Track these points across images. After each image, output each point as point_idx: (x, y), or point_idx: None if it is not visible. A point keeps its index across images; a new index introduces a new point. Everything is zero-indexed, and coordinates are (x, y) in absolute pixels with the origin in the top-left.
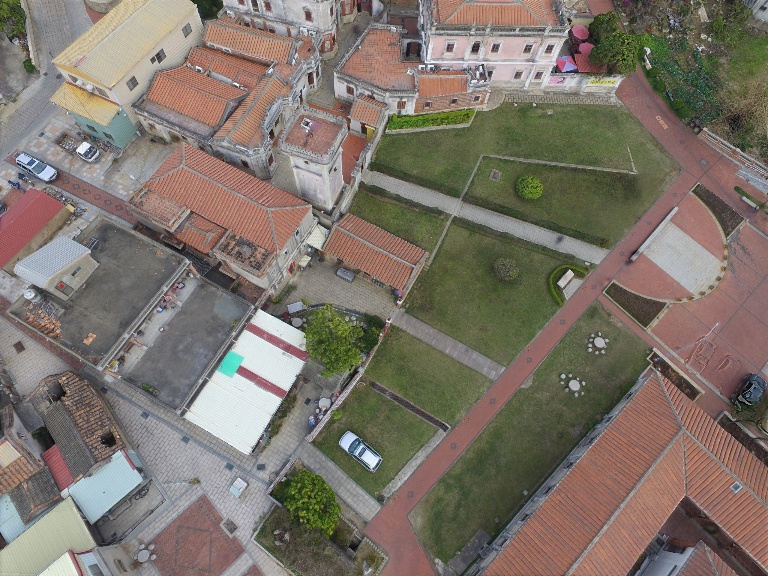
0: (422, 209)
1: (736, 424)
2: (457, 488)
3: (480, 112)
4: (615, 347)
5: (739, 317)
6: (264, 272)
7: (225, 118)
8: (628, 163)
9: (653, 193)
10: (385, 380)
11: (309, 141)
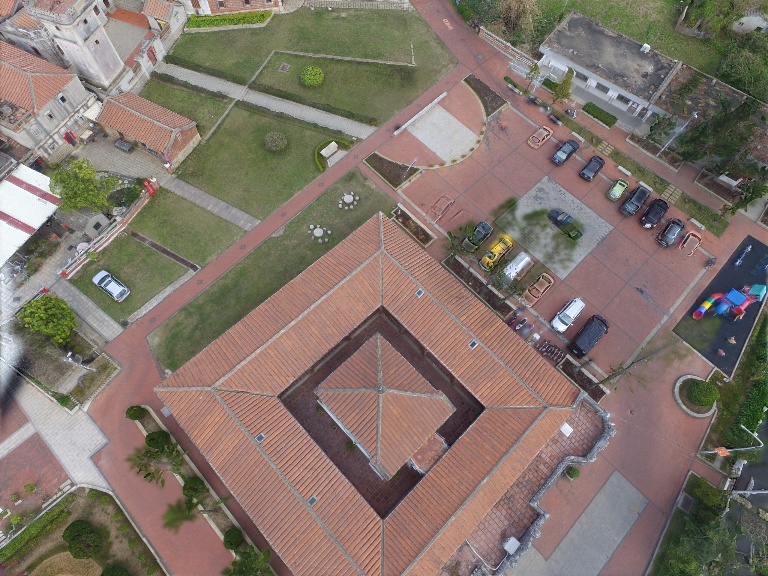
0: (208, 94)
1: (460, 262)
2: (197, 315)
3: (278, 15)
4: (365, 204)
5: (485, 180)
6: (20, 127)
7: (16, 9)
8: (409, 57)
9: (428, 82)
10: (147, 231)
11: (55, 7)
